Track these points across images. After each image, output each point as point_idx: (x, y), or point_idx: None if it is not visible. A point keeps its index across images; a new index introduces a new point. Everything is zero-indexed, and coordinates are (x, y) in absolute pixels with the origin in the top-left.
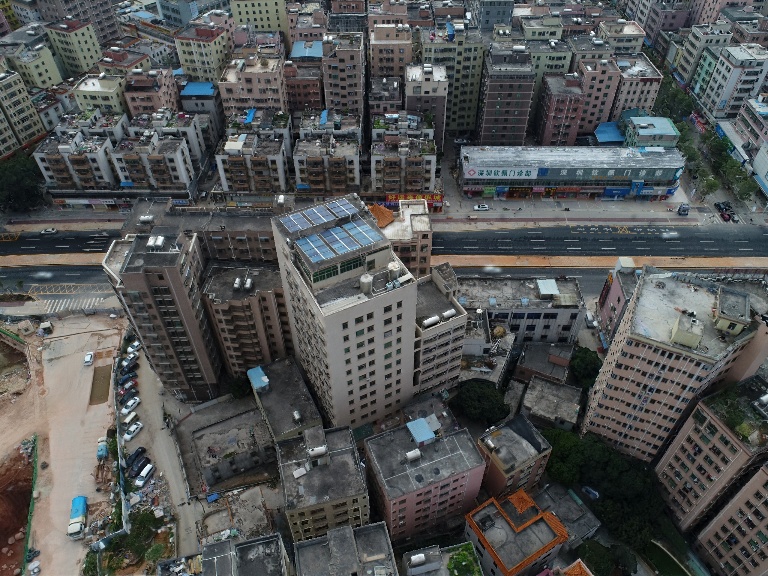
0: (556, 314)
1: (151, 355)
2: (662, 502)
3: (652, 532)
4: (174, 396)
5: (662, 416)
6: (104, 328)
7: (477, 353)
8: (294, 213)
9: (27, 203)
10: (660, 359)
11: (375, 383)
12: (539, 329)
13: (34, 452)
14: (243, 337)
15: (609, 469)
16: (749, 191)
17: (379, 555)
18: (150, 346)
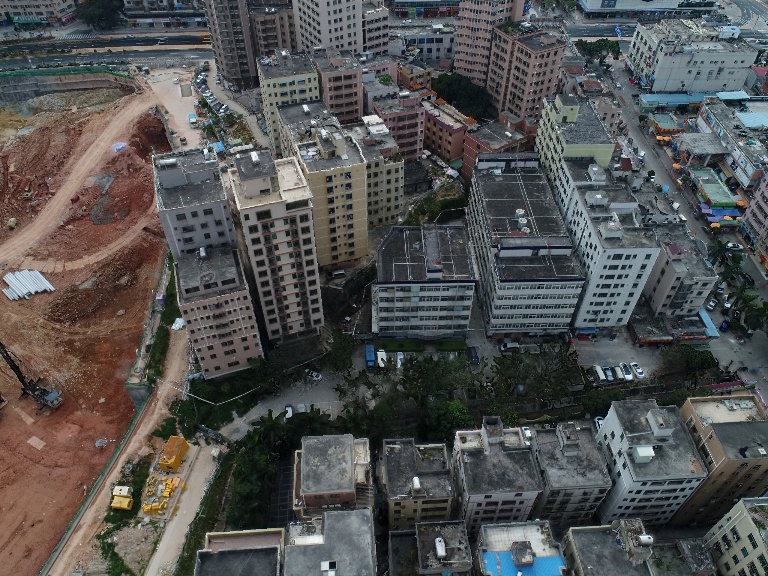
0: (442, 39)
1: (223, 48)
2: (488, 99)
3: (483, 111)
4: (230, 91)
5: (483, 48)
6: (180, 71)
7: (398, 54)
8: None
9: (112, 22)
10: (475, 7)
11: (343, 46)
12: (434, 52)
13: (157, 113)
14: (270, 46)
15: (461, 83)
16: (572, 5)
17: (348, 58)
18: (223, 41)
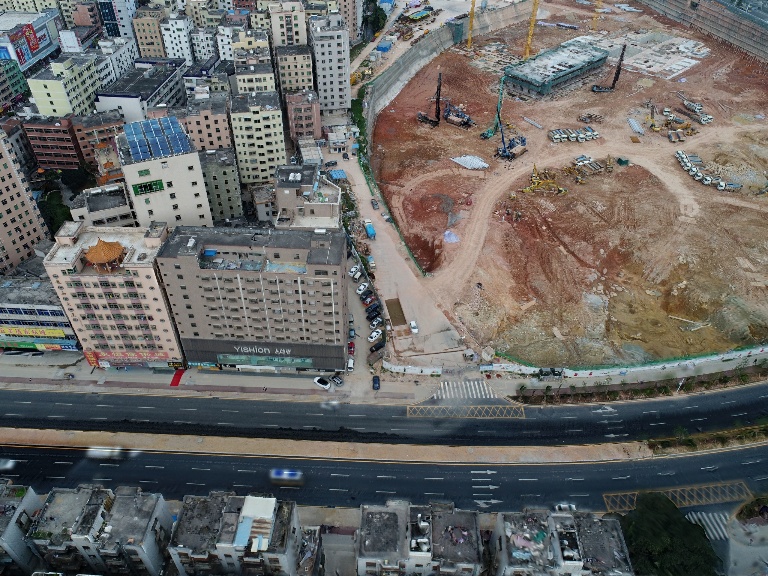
0: None
1: None
2: None
3: None
4: None
5: None
6: (415, 357)
7: None
8: (179, 154)
9: None
10: None
11: None
12: None
13: None
14: None
15: None
16: None
17: None
18: None
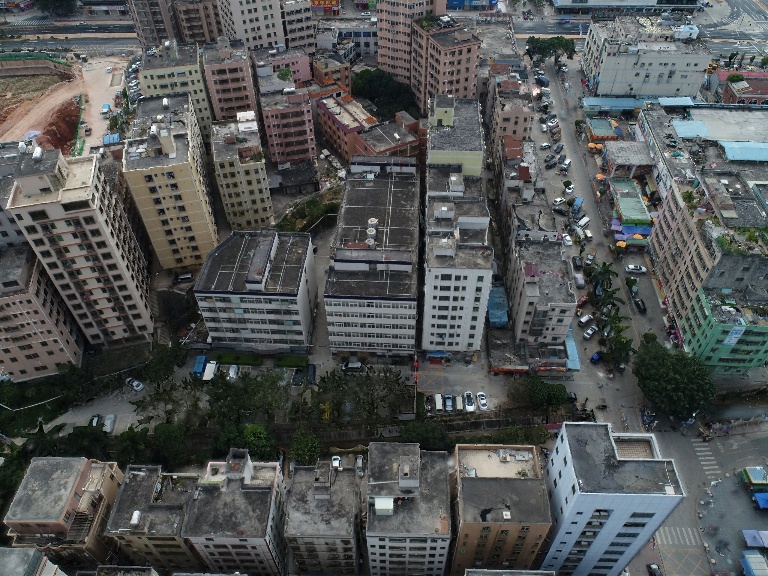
0: None
1: (144, 37)
2: (411, 98)
3: None
4: None
5: (404, 43)
6: (118, 60)
7: (329, 47)
8: None
9: (67, 8)
10: None
11: (262, 38)
12: (372, 46)
13: (80, 102)
14: (196, 36)
15: (382, 79)
16: None
17: (240, 50)
18: (144, 30)
